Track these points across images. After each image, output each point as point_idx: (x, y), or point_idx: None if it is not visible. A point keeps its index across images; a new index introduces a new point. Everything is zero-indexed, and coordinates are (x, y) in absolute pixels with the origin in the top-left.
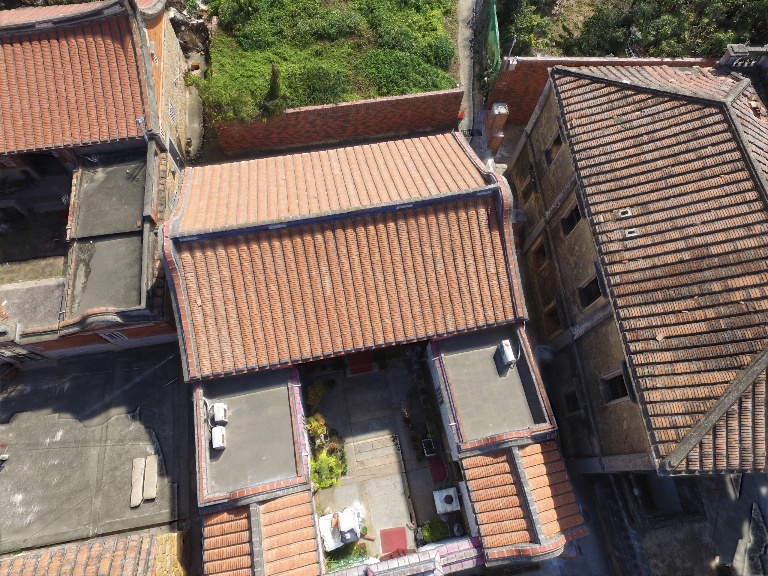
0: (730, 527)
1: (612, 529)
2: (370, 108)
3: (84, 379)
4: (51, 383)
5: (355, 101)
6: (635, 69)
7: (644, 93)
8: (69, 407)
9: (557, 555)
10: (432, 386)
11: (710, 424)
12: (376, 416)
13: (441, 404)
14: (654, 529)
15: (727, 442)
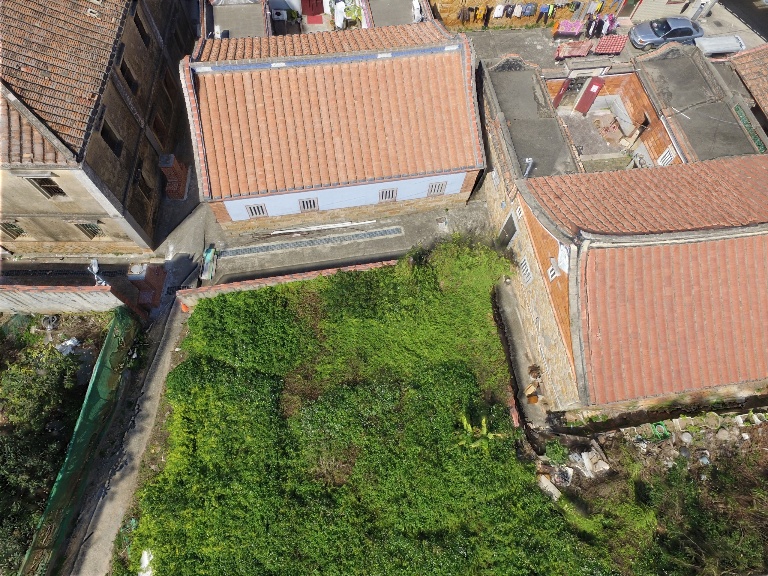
0: None
1: None
2: None
3: None
4: None
5: (317, 275)
6: None
7: (3, 80)
8: None
9: None
10: None
11: None
12: None
13: None
14: None
15: None
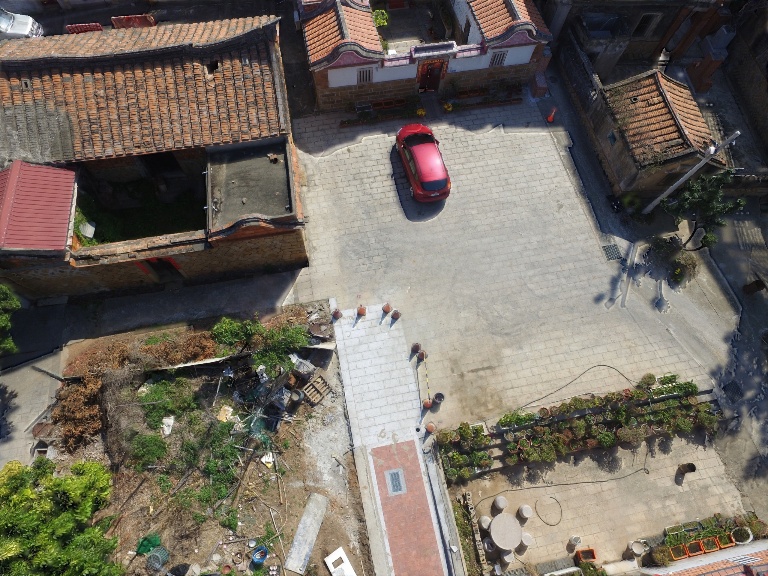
0: None
1: (571, 70)
2: None
3: (203, 8)
4: (181, 9)
5: None
6: None
7: None
8: (195, 21)
9: (531, 29)
10: (448, 5)
11: None
12: (408, 31)
13: (455, 0)
14: (596, 39)
15: None
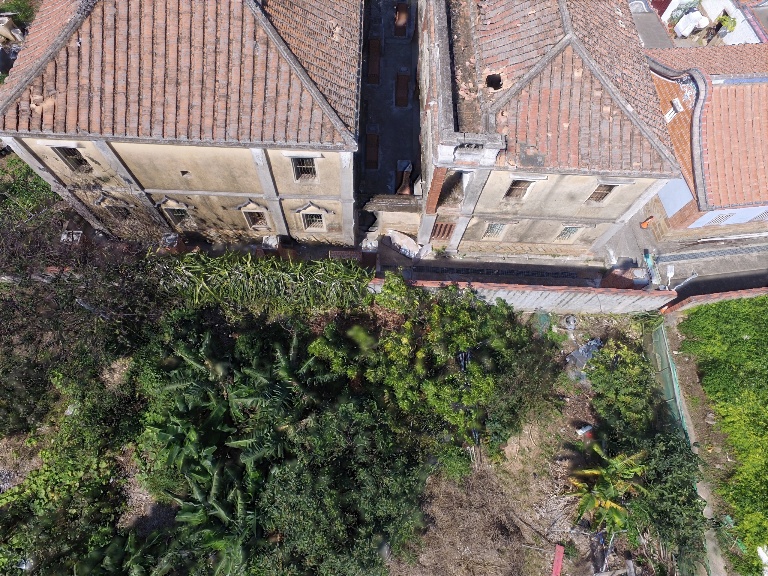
0: None
1: None
2: None
3: None
4: None
5: None
6: (590, 161)
7: None
8: None
9: None
10: None
11: None
12: None
13: None
14: None
15: None
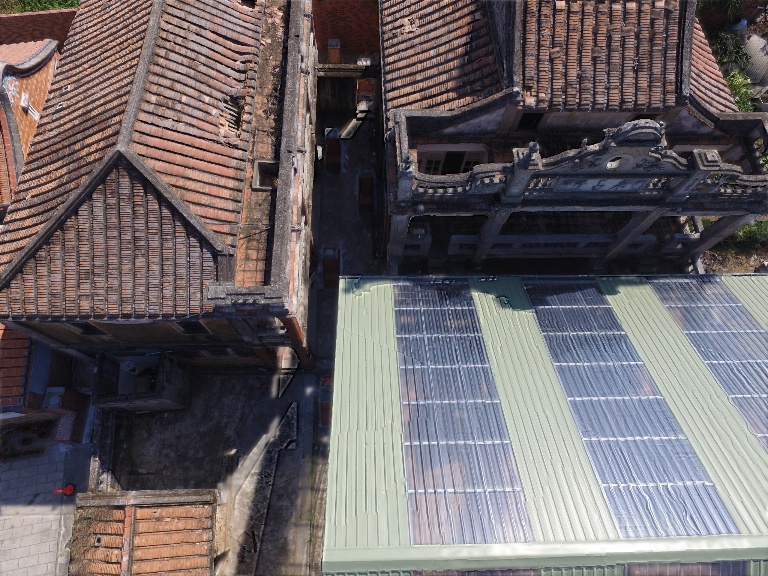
0: (259, 423)
1: None
2: (7, 24)
3: None
4: None
5: None
6: None
7: None
8: None
9: None
10: None
11: (10, 268)
12: None
13: None
14: (98, 404)
15: (37, 288)
